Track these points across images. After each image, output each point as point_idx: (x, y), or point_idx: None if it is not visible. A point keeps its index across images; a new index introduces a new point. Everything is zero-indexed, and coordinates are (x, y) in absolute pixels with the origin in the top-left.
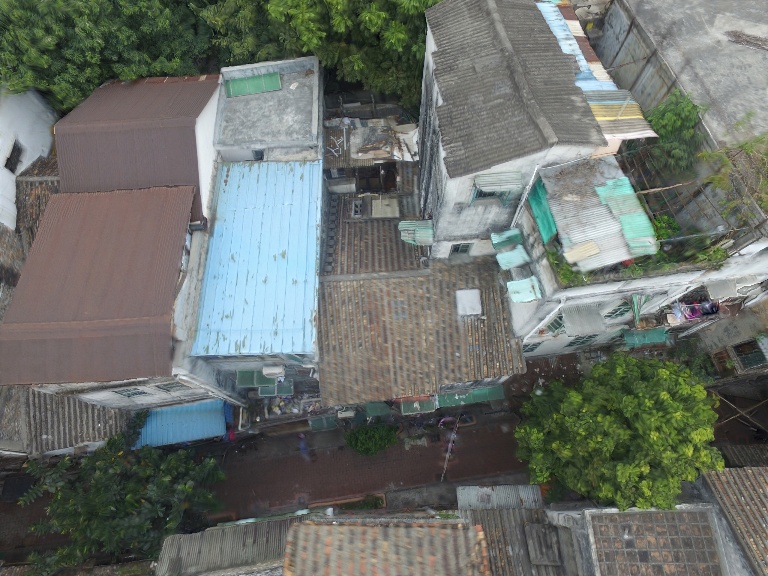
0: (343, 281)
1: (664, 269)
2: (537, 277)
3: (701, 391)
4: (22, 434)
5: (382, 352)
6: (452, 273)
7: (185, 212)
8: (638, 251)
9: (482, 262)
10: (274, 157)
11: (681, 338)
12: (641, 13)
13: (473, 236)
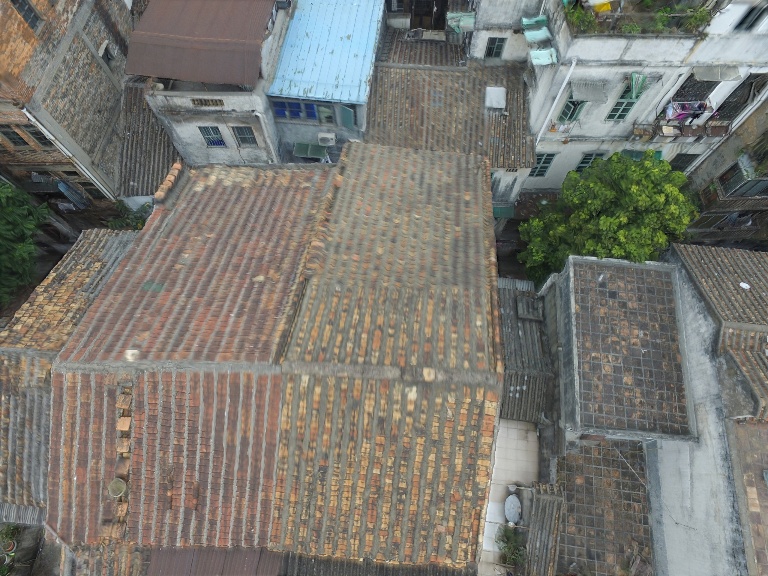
0: (394, 68)
1: (659, 28)
2: (556, 48)
3: None
4: (115, 177)
5: (418, 133)
6: (485, 73)
7: None
8: None
9: (511, 66)
10: None
11: None
12: None
13: (507, 27)
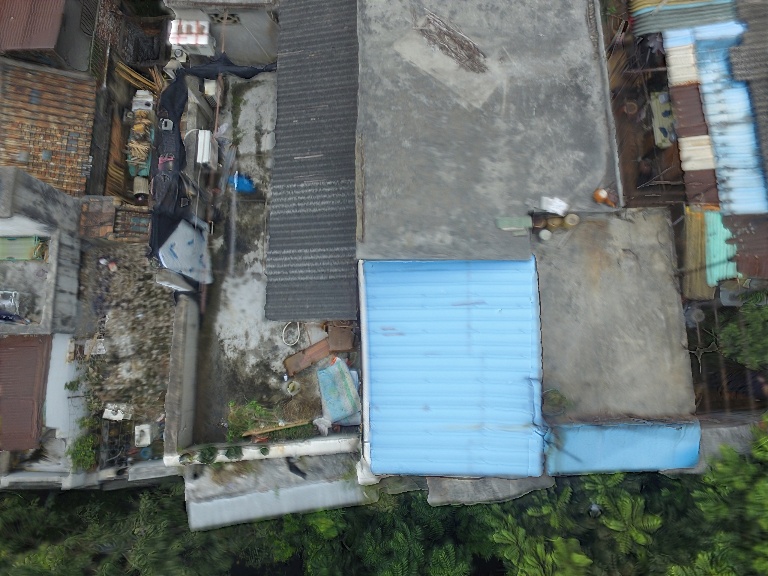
0: None
1: None
2: None
3: None
4: None
5: None
6: None
7: None
8: None
9: None
10: None
11: None
12: (594, 146)
13: None
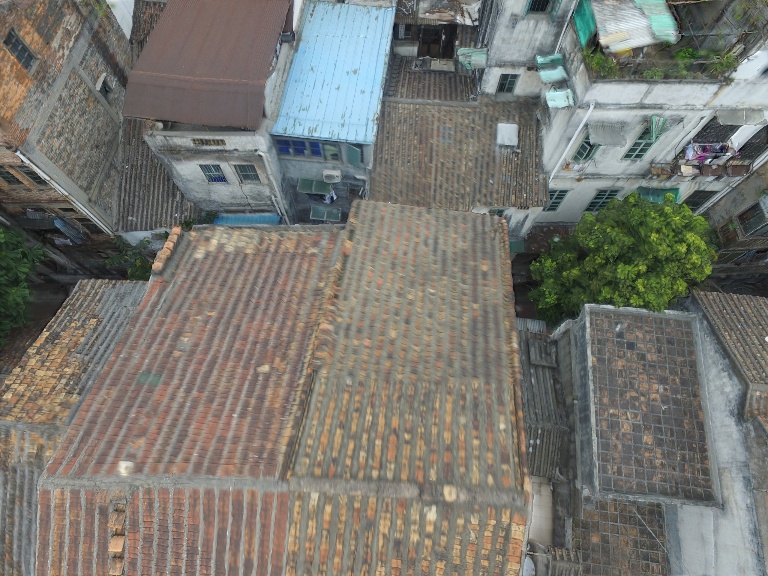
0: (402, 103)
1: (682, 73)
2: (572, 90)
3: None
4: (113, 212)
5: (426, 170)
6: (496, 109)
7: (282, 15)
8: (662, 38)
9: (524, 102)
10: (354, 2)
11: None
12: None
13: (521, 64)
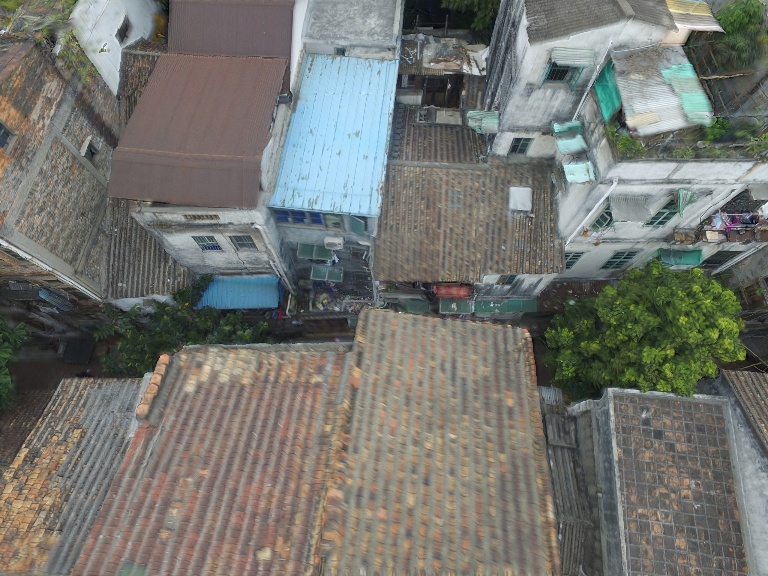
0: (407, 166)
1: (715, 153)
2: (593, 163)
3: (731, 296)
4: (101, 279)
5: (434, 237)
6: (508, 171)
7: (278, 78)
8: (695, 121)
9: (537, 164)
10: (355, 54)
11: (714, 275)
12: None
13: (535, 129)
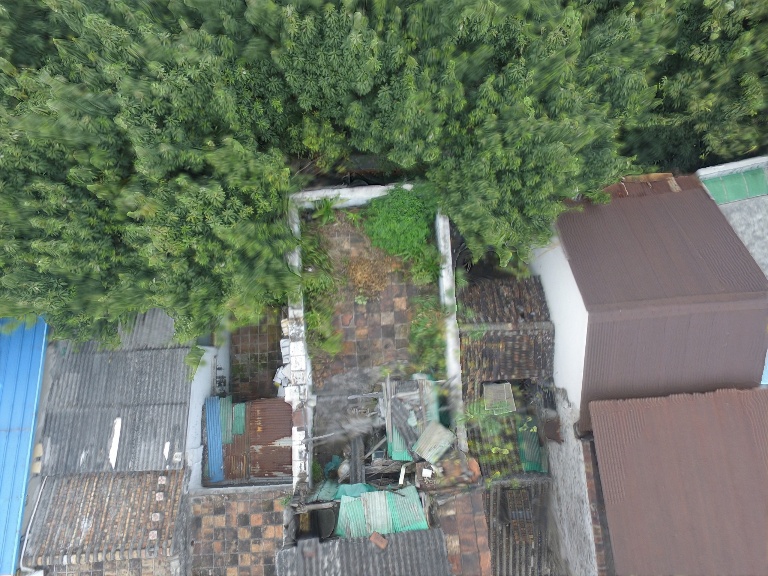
0: None
1: None
2: None
3: None
4: None
5: None
6: None
7: None
8: None
9: None
10: None
11: None
12: None
13: None
